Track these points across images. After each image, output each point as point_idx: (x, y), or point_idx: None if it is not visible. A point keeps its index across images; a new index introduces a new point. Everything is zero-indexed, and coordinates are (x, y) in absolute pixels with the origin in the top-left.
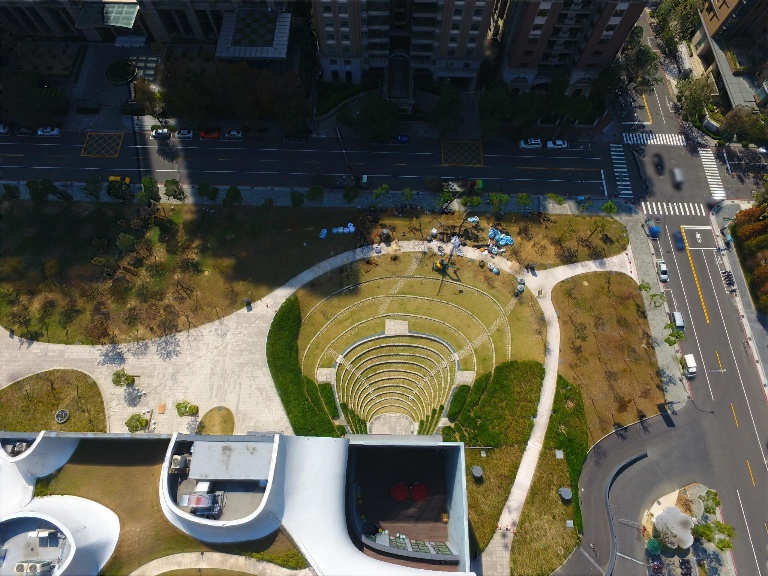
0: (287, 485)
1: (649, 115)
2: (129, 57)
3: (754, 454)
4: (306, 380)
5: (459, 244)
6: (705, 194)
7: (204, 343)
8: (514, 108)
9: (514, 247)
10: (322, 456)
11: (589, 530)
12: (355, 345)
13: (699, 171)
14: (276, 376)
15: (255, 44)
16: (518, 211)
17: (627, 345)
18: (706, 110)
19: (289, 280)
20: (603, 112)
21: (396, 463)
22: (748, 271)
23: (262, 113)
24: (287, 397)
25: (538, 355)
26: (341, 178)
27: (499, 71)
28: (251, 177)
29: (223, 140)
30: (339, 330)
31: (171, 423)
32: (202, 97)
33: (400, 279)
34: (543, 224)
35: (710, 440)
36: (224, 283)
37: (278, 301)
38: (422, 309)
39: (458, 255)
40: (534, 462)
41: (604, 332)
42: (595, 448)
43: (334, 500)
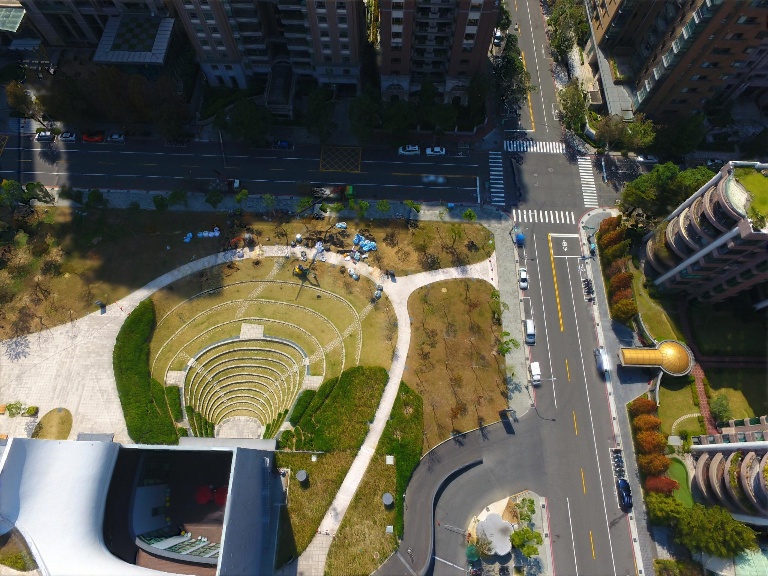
0: (24, 488)
1: (532, 123)
2: (22, 60)
3: (589, 462)
4: (152, 383)
5: (323, 249)
6: (577, 202)
7: (53, 345)
8: (384, 115)
9: (377, 253)
10: (73, 459)
11: (410, 535)
12: (208, 348)
13: (575, 179)
14: (119, 378)
15: (134, 49)
16: (388, 217)
17: (477, 352)
18: (587, 118)
19: (147, 283)
20: (483, 119)
21: (209, 466)
22: (608, 280)
23: (143, 117)
24: (127, 399)
25: (385, 361)
26: (214, 182)
27: (378, 78)
28: (128, 180)
29: (106, 143)
30: (194, 333)
31: (10, 423)
32: (74, 101)
33: (260, 283)
34: (410, 230)
35: (547, 448)
36: (82, 285)
37: (133, 304)
38: (279, 314)
39: (320, 260)
40: (364, 467)
41: (455, 339)
42: (430, 454)
43: (81, 503)
